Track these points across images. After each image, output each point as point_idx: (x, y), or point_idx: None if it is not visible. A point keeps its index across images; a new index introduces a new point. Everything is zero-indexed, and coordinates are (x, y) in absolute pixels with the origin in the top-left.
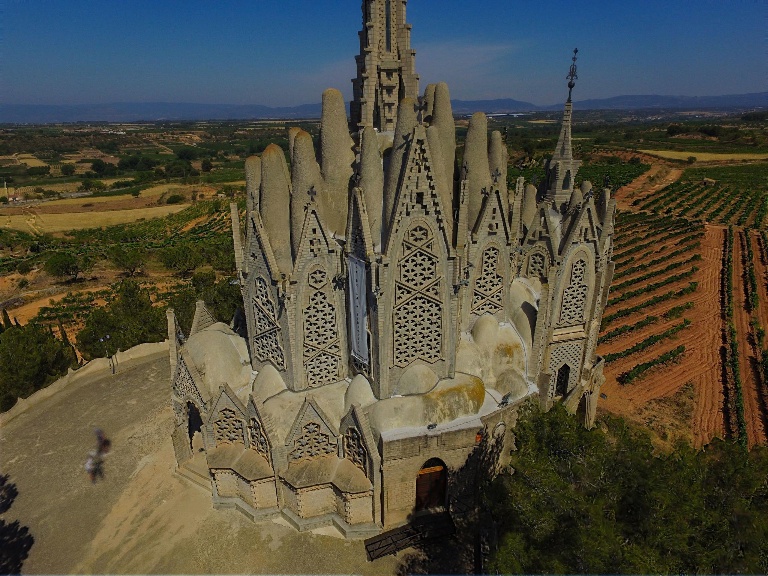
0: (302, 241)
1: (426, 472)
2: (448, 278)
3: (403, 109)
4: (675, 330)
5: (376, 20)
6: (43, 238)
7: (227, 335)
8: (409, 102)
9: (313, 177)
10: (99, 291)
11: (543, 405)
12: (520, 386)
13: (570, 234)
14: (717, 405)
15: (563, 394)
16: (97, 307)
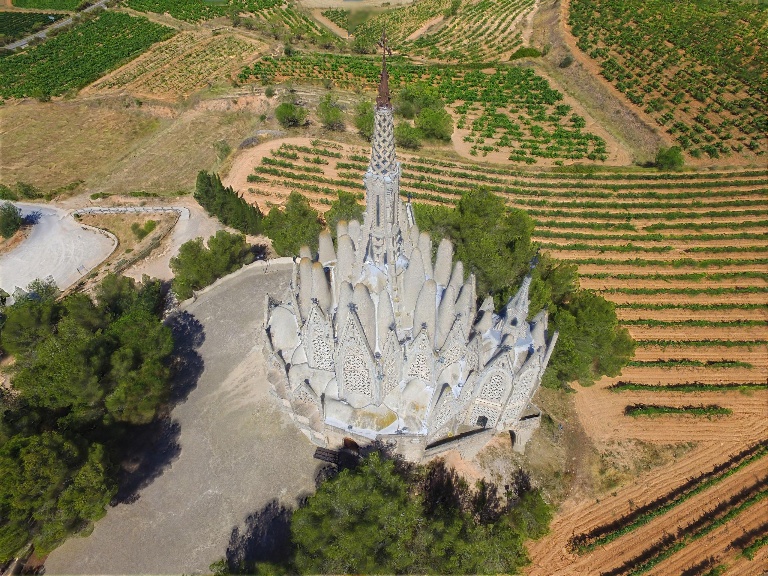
0: (308, 317)
1: (349, 439)
2: (373, 371)
3: (355, 290)
4: (754, 388)
5: (369, 212)
6: (299, 29)
7: (293, 315)
8: (358, 289)
9: (320, 287)
10: (302, 147)
11: (454, 431)
12: (414, 428)
13: (492, 361)
14: (693, 473)
15: (484, 427)
16: (296, 166)
